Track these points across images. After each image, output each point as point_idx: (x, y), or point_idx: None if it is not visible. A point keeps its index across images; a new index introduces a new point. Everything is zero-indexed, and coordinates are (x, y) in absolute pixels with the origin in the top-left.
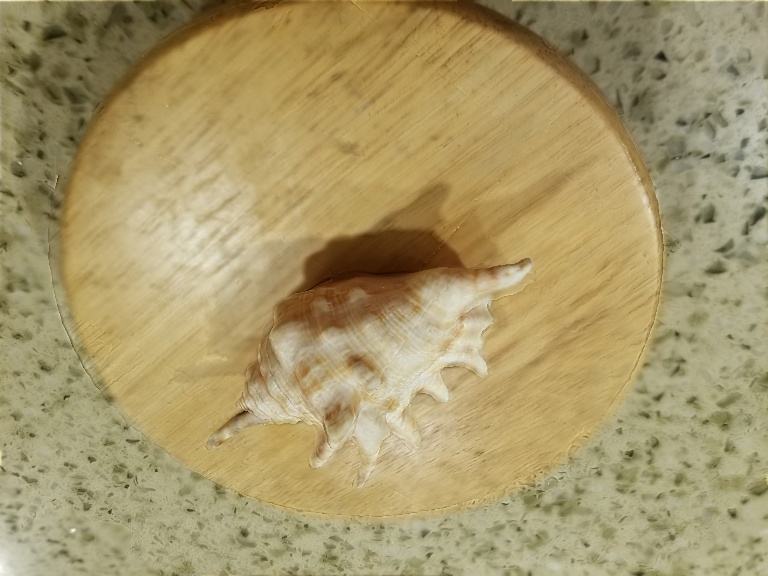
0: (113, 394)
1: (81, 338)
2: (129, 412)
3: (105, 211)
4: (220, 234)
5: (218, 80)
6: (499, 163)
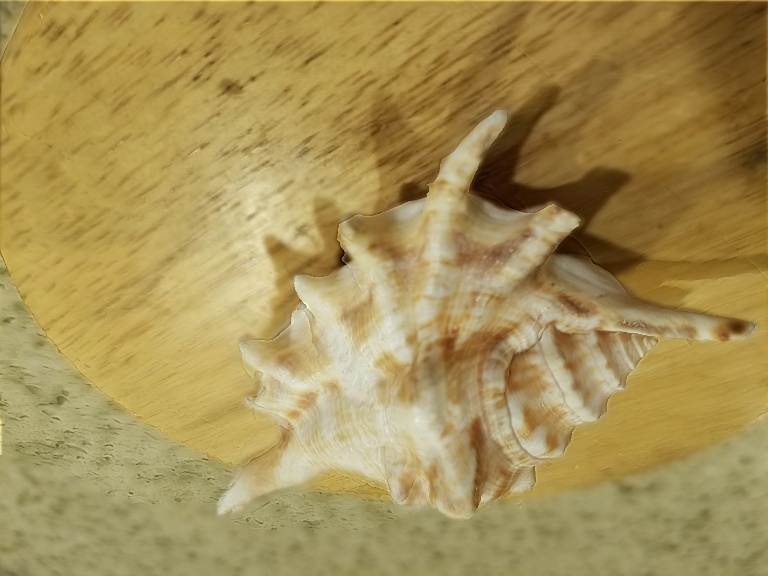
0: None
1: None
2: None
3: None
4: None
5: None
6: (278, 432)
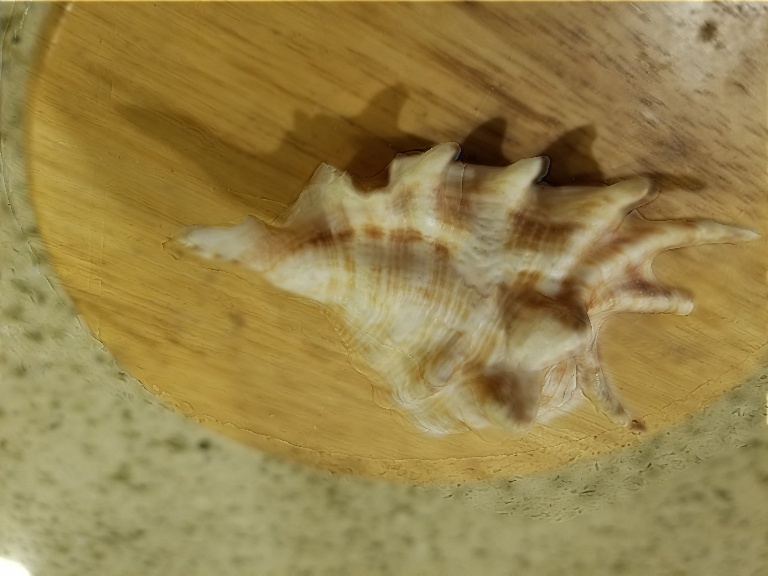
0: (612, 424)
1: (540, 443)
2: (639, 412)
3: None
4: None
5: (228, 396)
6: (151, 180)
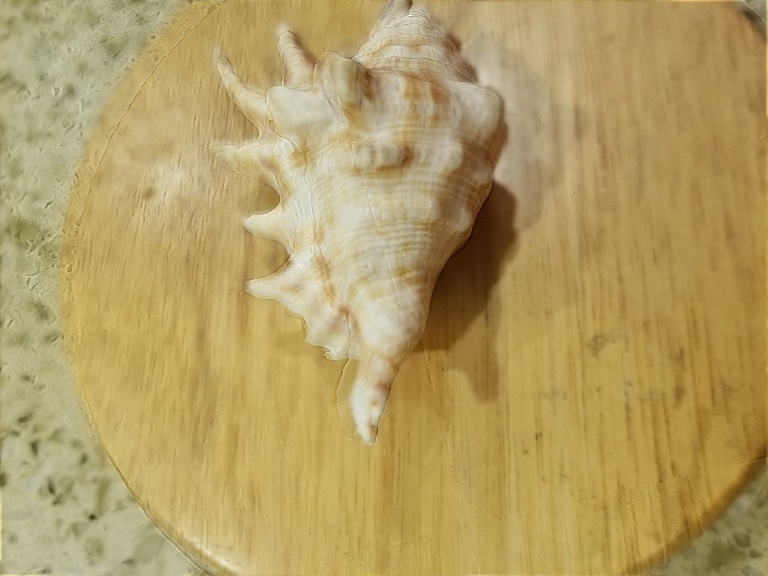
0: None
1: None
2: None
3: (713, 54)
4: (605, 142)
5: None
6: (474, 480)
